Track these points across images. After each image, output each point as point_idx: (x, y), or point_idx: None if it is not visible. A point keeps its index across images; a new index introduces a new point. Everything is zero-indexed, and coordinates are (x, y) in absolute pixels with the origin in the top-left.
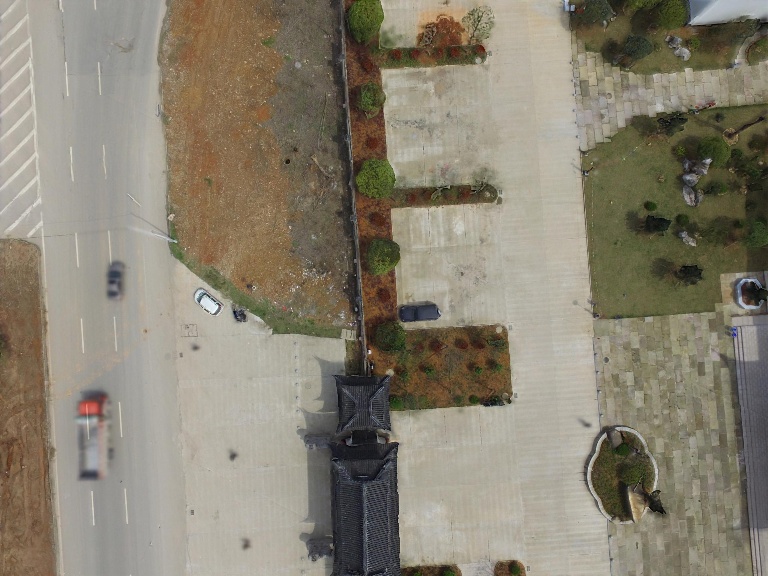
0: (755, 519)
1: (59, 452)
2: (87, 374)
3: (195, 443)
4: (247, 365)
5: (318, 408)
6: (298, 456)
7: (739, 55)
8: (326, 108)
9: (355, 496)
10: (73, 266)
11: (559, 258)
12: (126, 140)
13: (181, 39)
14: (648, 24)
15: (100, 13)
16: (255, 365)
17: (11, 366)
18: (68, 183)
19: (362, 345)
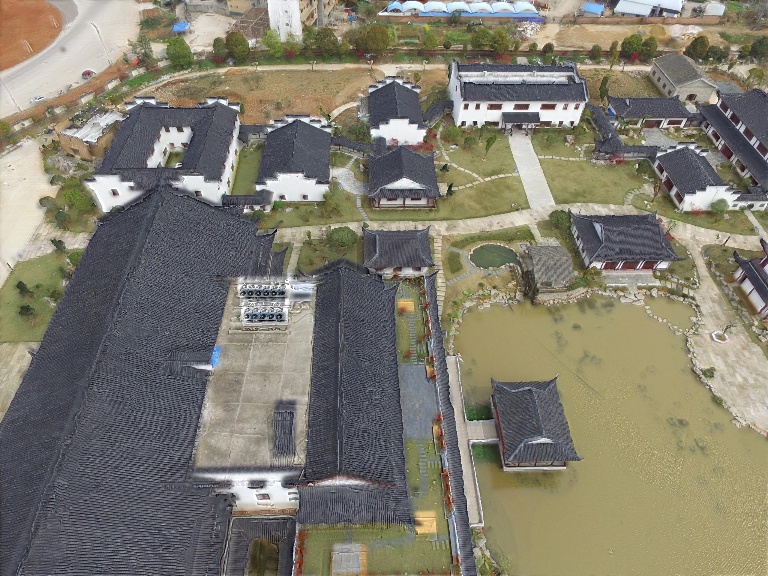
0: None
1: None
2: None
3: None
4: None
5: None
6: None
7: None
8: None
9: None
10: None
11: None
12: None
13: None
14: None
15: None
16: None
17: None
18: None
19: None
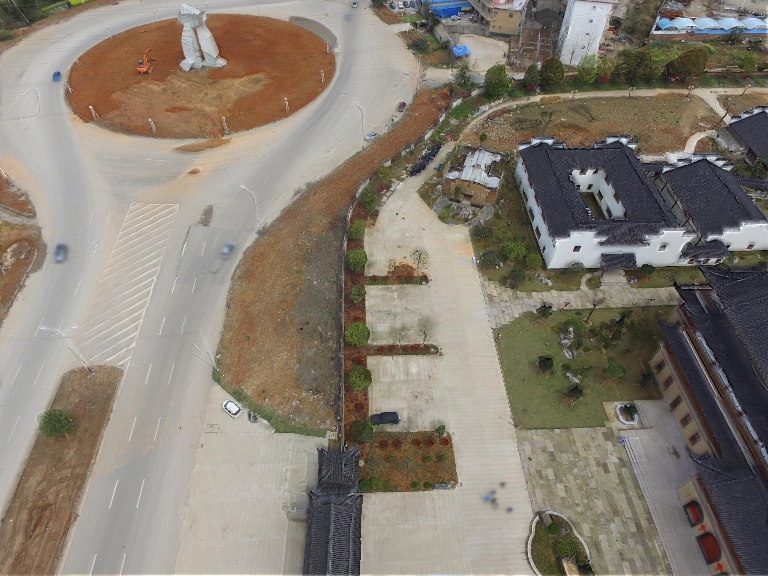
0: None
1: (81, 518)
2: (126, 456)
3: (196, 515)
4: (251, 454)
5: (302, 489)
6: (280, 529)
7: (582, 284)
8: (330, 303)
9: (325, 517)
10: (142, 383)
11: (485, 389)
12: (201, 315)
13: (248, 269)
14: (523, 269)
15: (204, 257)
16: (257, 454)
17: (72, 447)
18: (156, 336)
19: (341, 439)
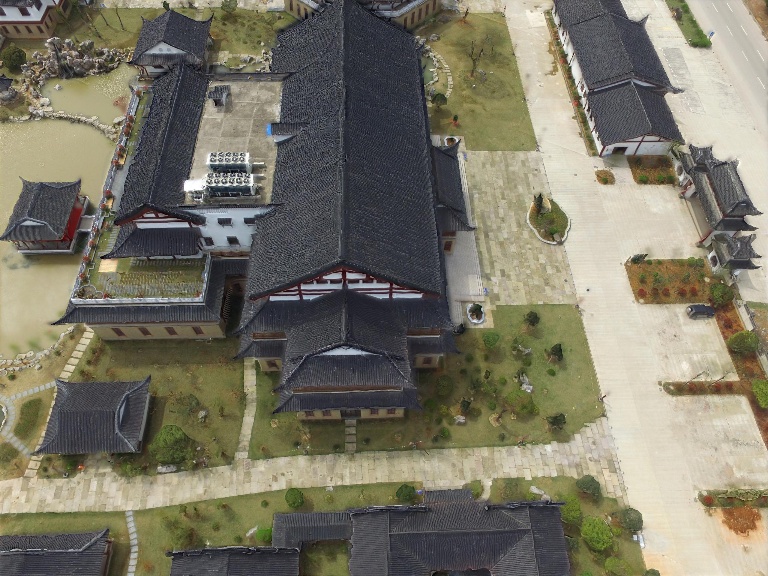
0: (466, 196)
1: None
2: None
3: None
4: None
5: None
6: None
7: (489, 489)
8: None
9: None
10: None
11: (609, 343)
12: None
13: None
14: None
15: None
16: None
17: None
18: None
19: None
